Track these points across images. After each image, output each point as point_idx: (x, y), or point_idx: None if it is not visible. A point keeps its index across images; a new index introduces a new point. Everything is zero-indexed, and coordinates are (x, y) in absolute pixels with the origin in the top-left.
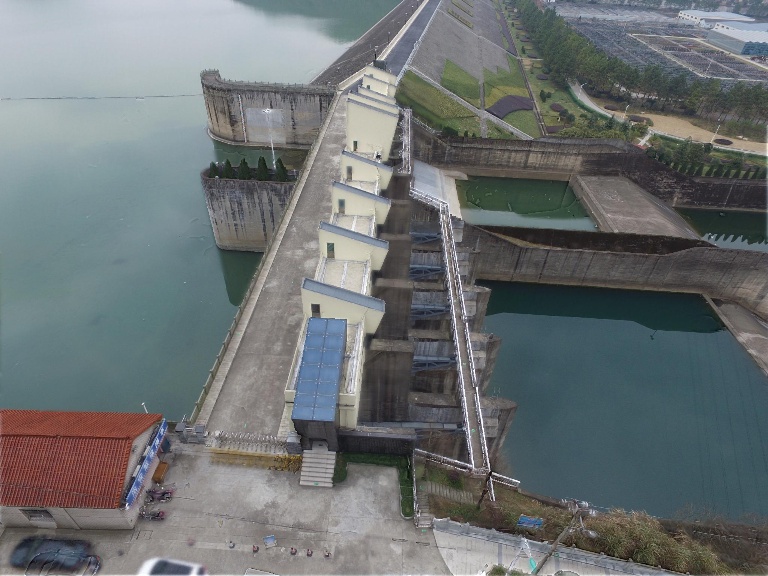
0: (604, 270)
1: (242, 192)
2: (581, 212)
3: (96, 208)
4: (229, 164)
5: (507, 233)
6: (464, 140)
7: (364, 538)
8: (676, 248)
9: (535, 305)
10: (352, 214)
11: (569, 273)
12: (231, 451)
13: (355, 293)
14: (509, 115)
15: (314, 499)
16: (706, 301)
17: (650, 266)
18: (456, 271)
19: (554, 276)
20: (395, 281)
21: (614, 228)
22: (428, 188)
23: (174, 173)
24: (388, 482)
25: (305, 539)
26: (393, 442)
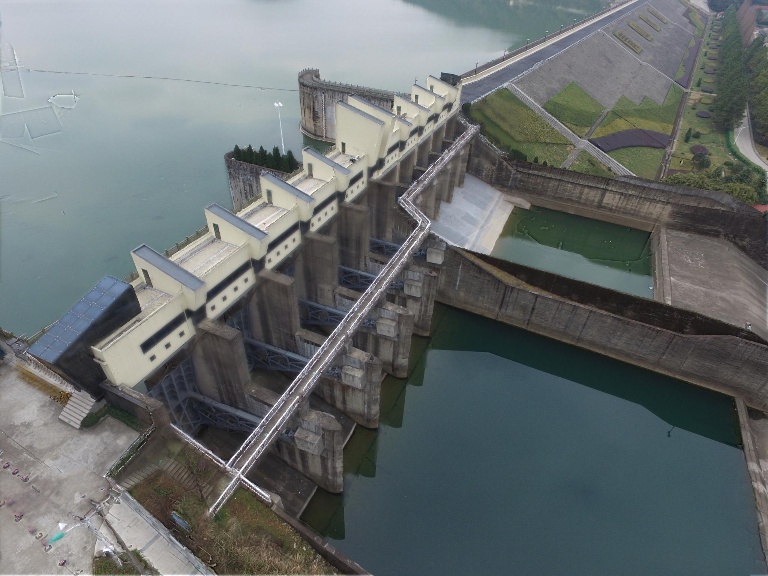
0: (603, 334)
1: (252, 176)
2: (644, 269)
3: (173, 173)
4: (250, 149)
5: (503, 267)
6: (532, 166)
7: (63, 479)
8: (710, 331)
9: (524, 354)
10: (279, 206)
11: (561, 327)
12: (39, 374)
13: (182, 269)
14: (621, 150)
15: (58, 433)
16: (735, 407)
17: (663, 344)
18: (385, 286)
19: (544, 326)
20: (279, 275)
21: (667, 294)
22: (473, 209)
23: None
24: (124, 443)
25: (23, 460)
26: (138, 408)
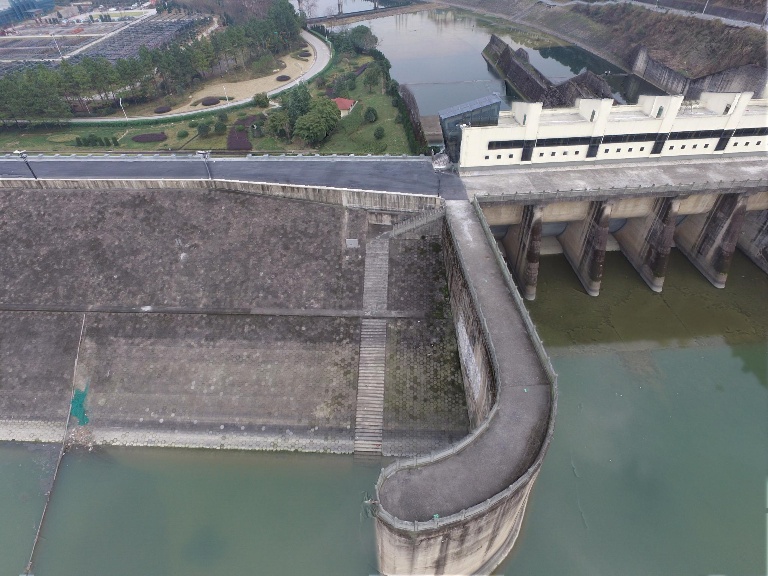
0: None
1: None
2: None
3: None
4: None
5: None
6: None
7: None
8: None
9: None
10: None
11: None
12: None
13: None
14: None
15: None
16: None
17: None
18: None
19: None
20: None
21: None
22: None
23: (764, 554)
24: None
25: None
26: None
